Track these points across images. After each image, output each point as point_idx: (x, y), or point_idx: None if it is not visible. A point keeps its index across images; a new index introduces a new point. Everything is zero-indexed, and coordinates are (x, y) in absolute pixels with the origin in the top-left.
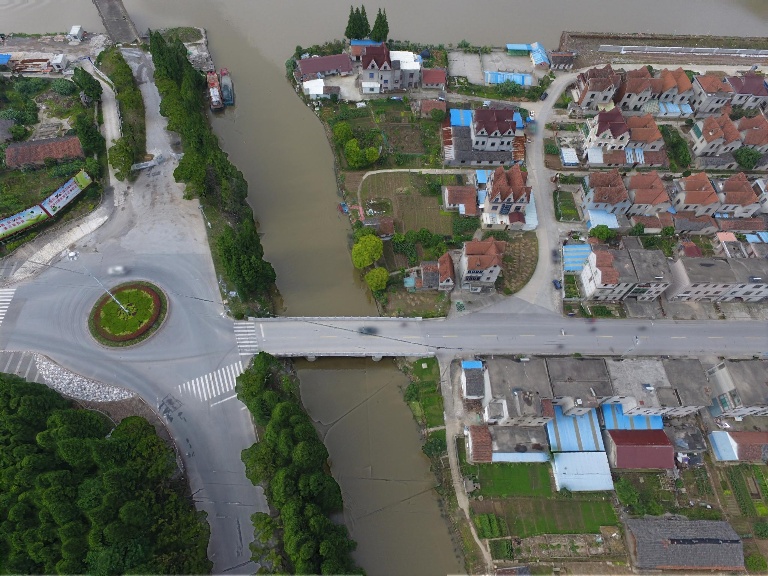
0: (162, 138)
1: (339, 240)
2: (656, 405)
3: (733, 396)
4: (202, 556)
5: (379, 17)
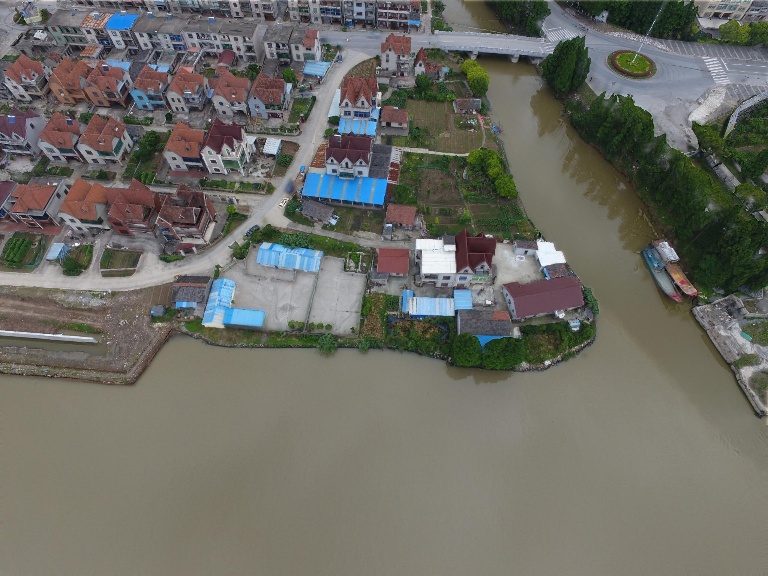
0: None
1: None
2: None
3: None
4: None
5: None
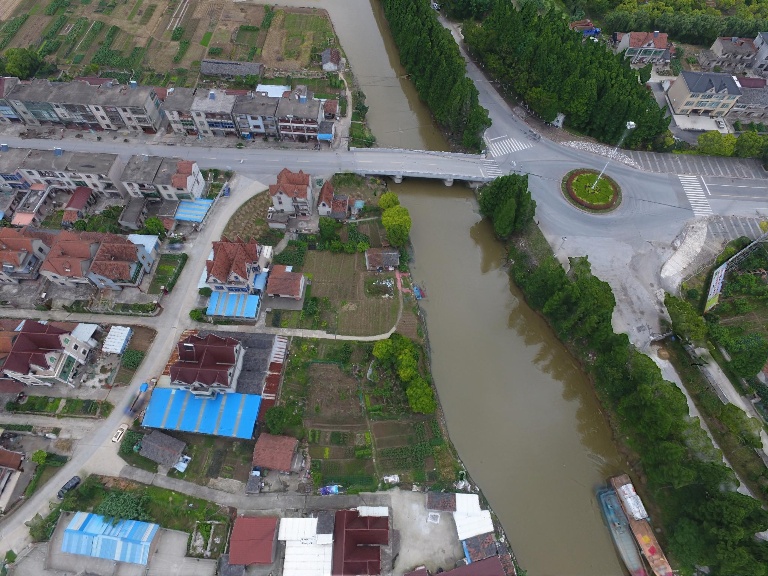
0: None
1: None
2: (213, 90)
3: (152, 98)
4: None
5: None
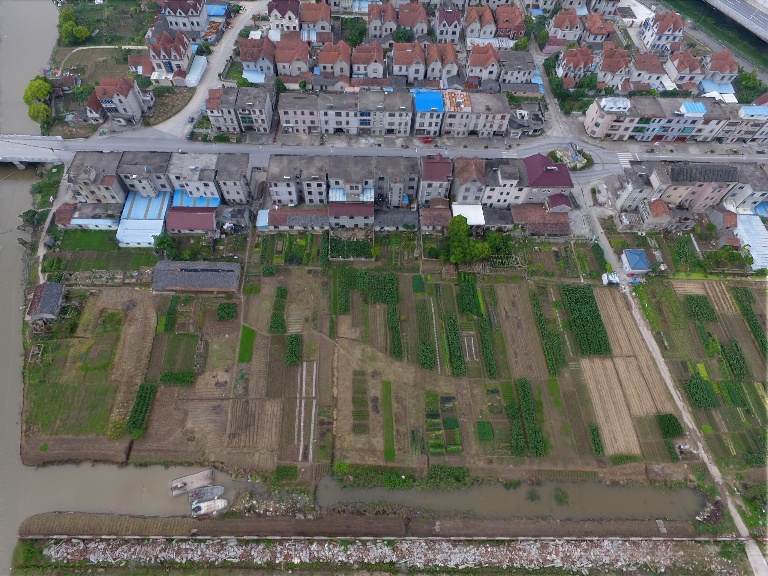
0: None
1: None
2: (195, 179)
3: None
4: None
5: None
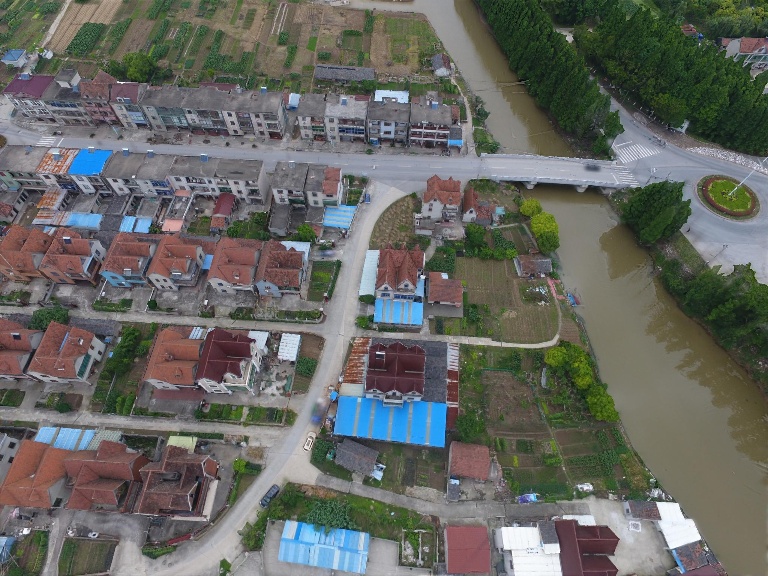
0: None
1: None
2: (343, 96)
3: (281, 104)
4: None
5: None
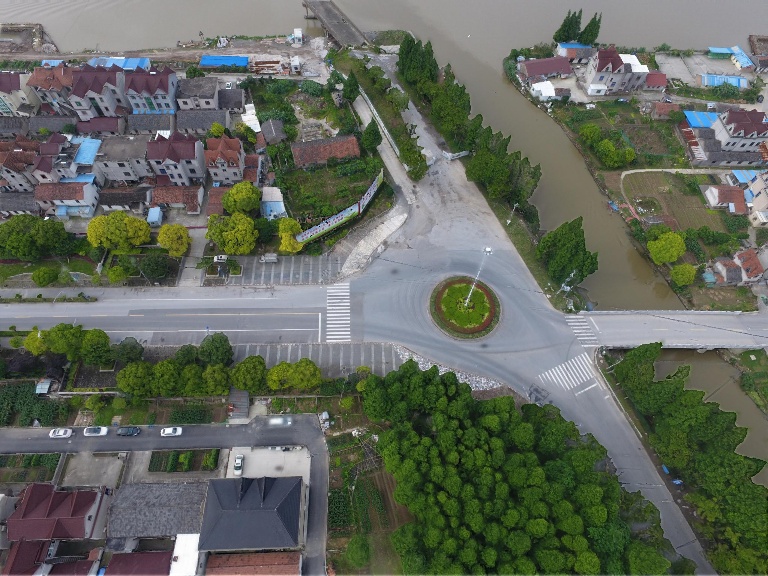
0: (427, 138)
1: (612, 237)
2: None
3: None
4: (662, 534)
5: (594, 21)
